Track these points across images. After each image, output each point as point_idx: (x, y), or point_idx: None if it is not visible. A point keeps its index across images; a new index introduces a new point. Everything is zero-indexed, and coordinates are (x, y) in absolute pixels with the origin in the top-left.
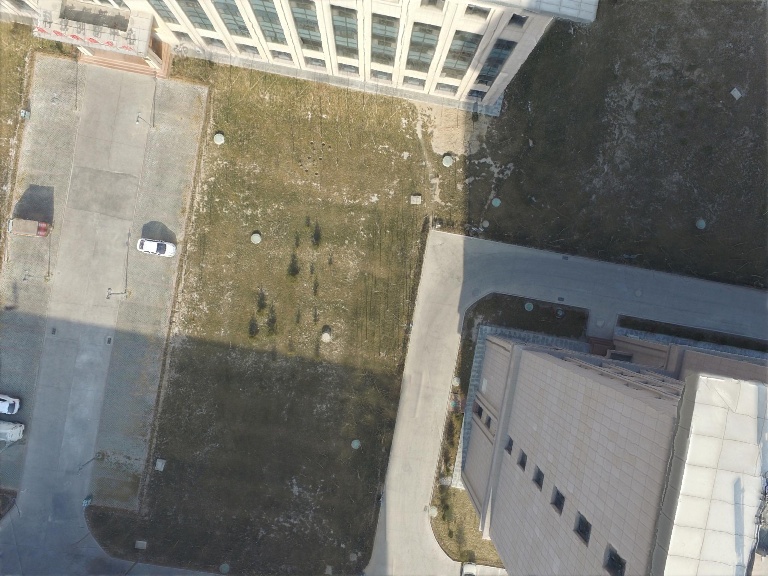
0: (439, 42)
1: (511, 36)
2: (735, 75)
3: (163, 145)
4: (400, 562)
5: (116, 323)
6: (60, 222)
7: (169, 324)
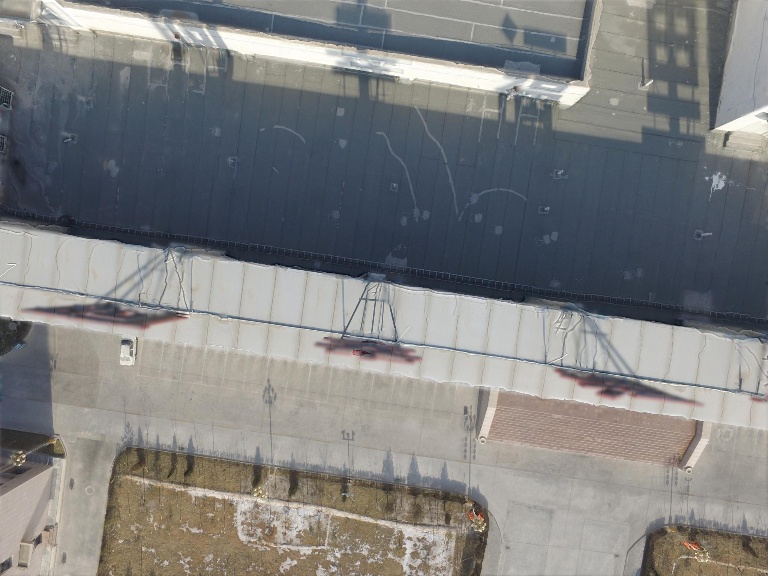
0: None
1: None
2: None
3: None
4: (62, 332)
5: None
6: None
7: None
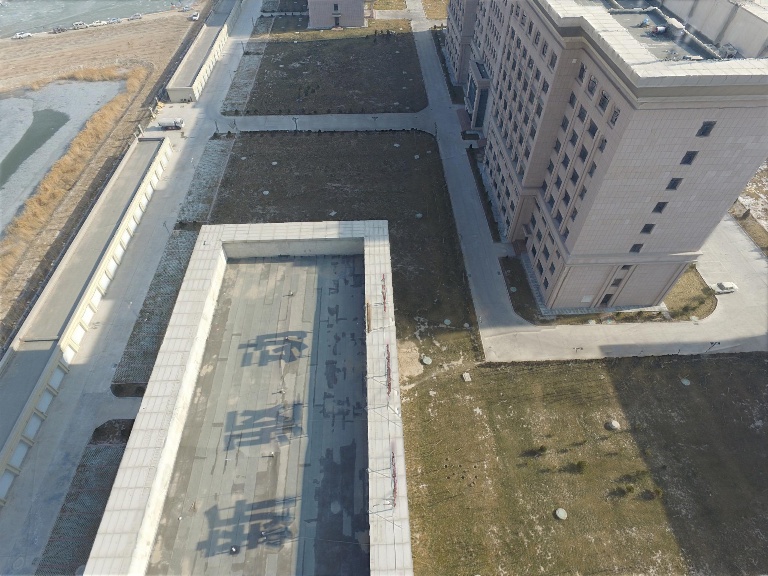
0: None
1: None
2: (321, 216)
3: None
4: (748, 333)
5: None
6: None
7: None
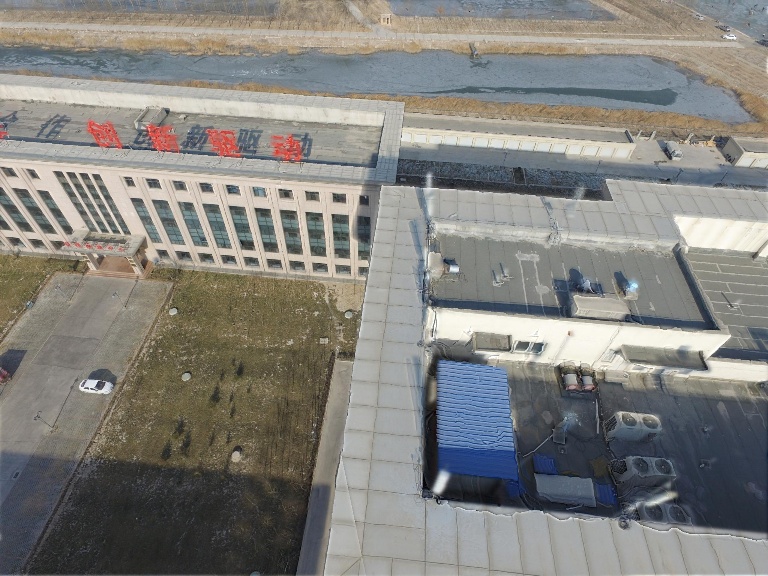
0: (324, 226)
1: (365, 213)
2: None
3: (128, 318)
4: None
5: (31, 457)
6: (20, 375)
7: (83, 454)
